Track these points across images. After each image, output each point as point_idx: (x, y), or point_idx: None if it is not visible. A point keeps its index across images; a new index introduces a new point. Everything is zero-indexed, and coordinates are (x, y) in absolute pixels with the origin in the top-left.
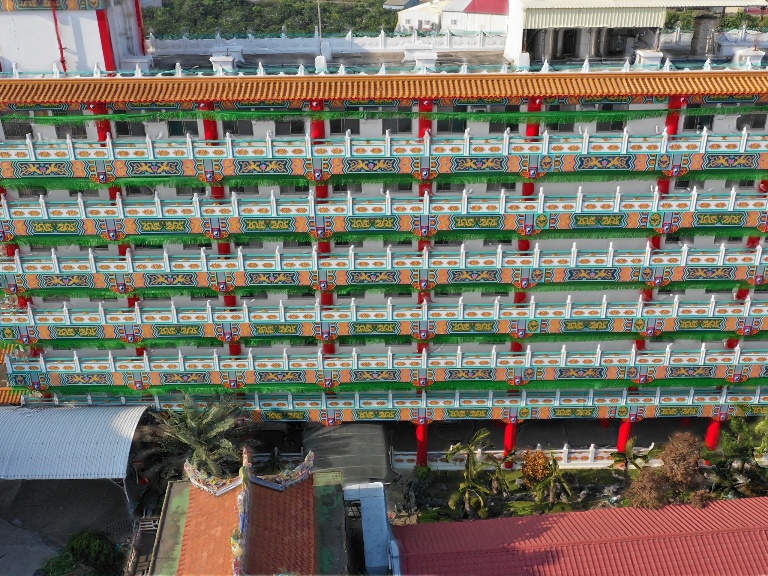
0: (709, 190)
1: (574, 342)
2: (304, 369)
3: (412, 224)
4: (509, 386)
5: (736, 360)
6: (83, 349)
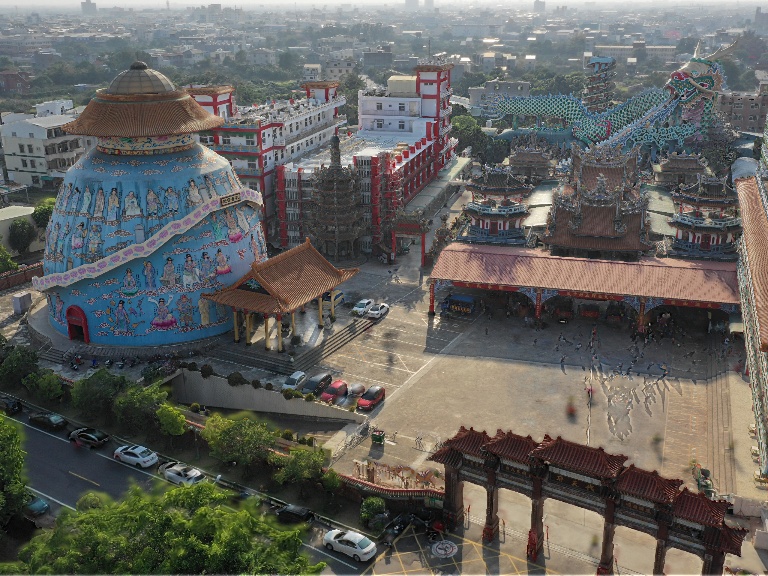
0: None
1: None
2: None
3: None
4: None
5: None
6: None
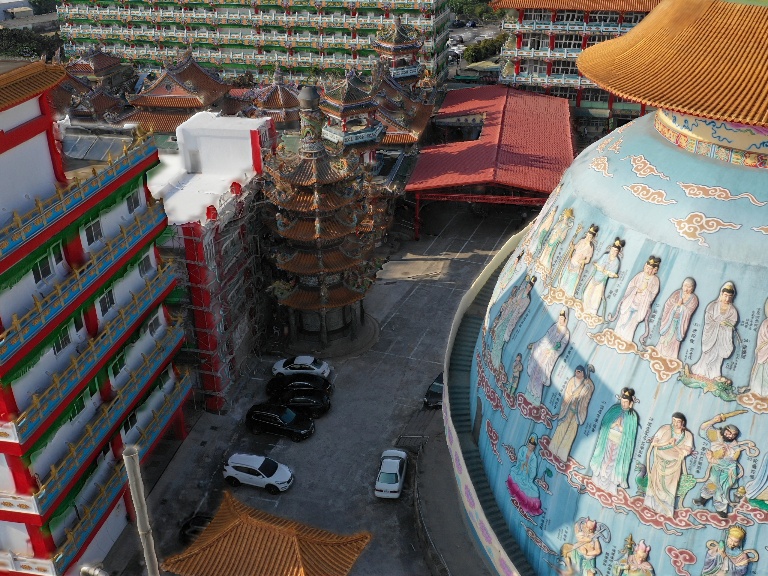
0: None
1: (234, 49)
2: (152, 54)
3: (177, 0)
4: (216, 65)
5: (288, 59)
6: (87, 43)
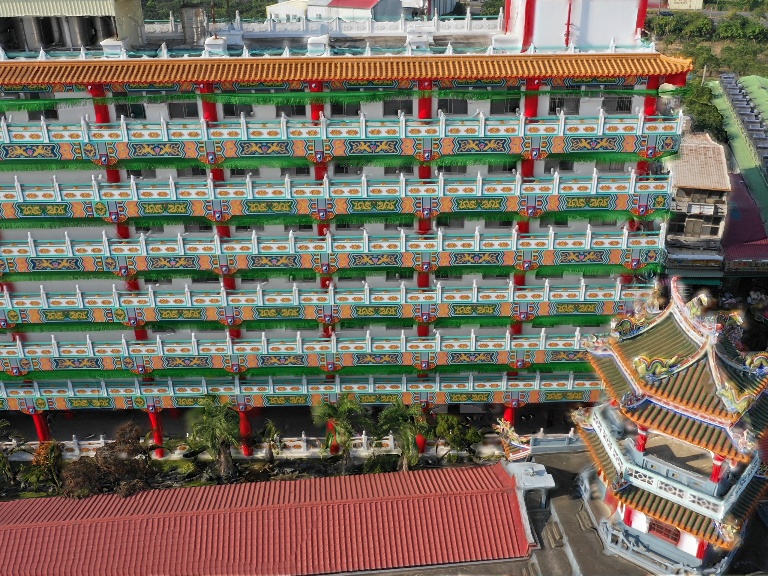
0: (156, 179)
1: (62, 332)
2: None
3: None
4: (9, 377)
5: (230, 350)
6: None
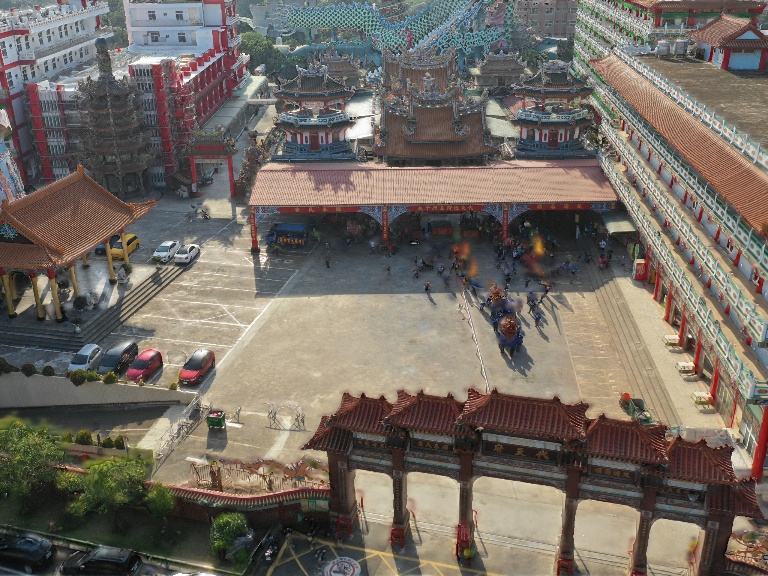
0: None
1: None
2: None
3: None
4: None
5: None
6: None
